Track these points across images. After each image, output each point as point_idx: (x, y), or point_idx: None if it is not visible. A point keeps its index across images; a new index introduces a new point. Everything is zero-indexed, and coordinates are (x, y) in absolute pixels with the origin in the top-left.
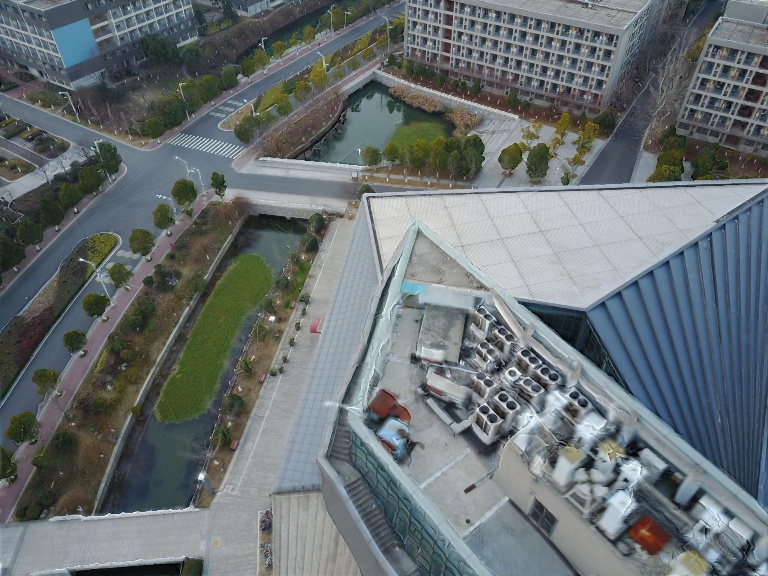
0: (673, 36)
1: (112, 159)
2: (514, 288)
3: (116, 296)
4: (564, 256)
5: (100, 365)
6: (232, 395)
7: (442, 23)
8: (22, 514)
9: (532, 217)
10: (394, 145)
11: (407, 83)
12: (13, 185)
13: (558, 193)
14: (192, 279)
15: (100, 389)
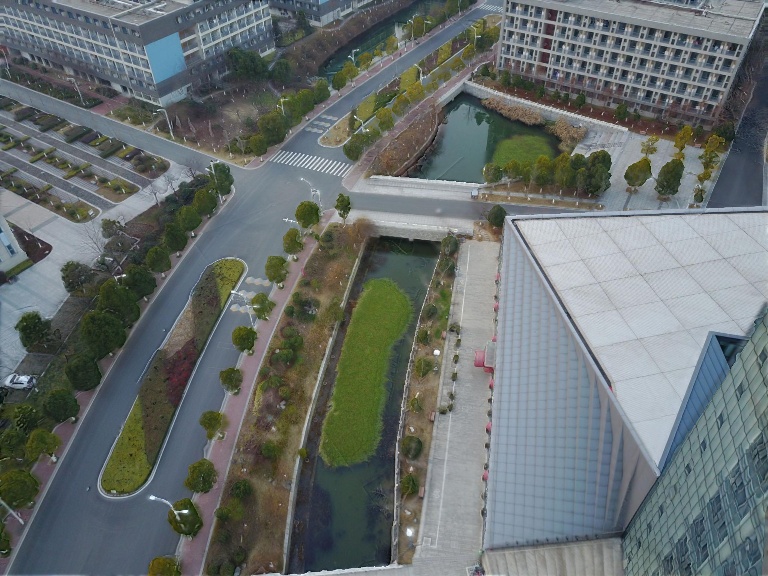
0: (766, 42)
1: (226, 180)
2: (720, 323)
3: (256, 327)
4: (763, 287)
5: (257, 403)
6: (412, 437)
7: (542, 33)
8: (215, 572)
9: (708, 242)
10: (516, 162)
11: (502, 94)
12: (120, 207)
13: (726, 215)
14: (330, 307)
15: (264, 430)
